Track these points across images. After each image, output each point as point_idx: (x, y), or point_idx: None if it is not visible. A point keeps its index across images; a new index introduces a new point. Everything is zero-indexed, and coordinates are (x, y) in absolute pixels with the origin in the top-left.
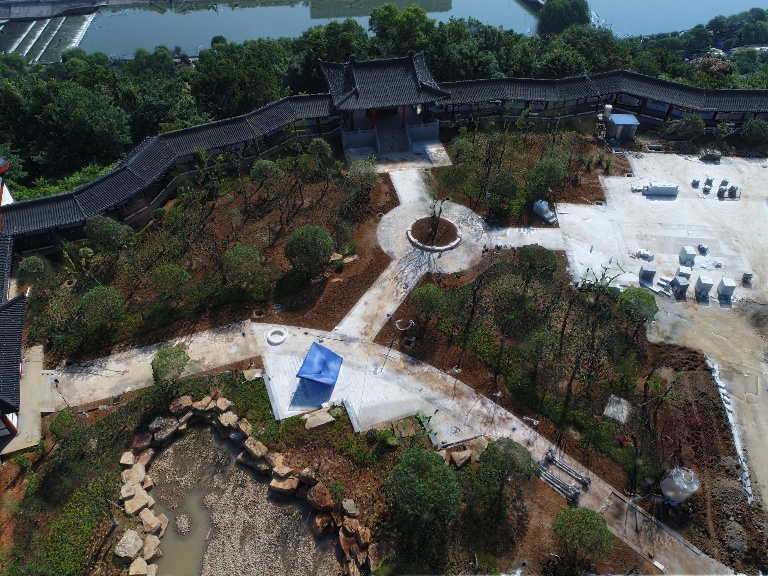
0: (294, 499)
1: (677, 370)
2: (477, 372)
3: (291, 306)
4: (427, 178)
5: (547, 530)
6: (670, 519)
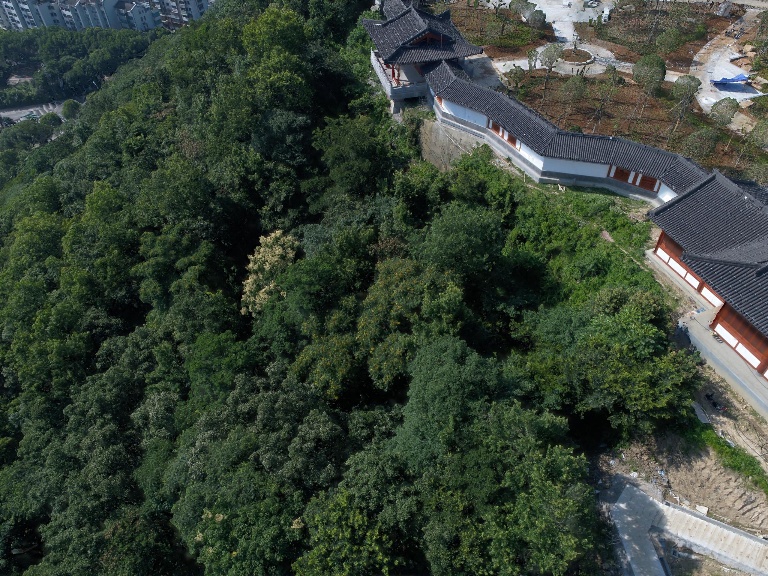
0: None
1: None
2: (690, 47)
3: None
4: (505, 60)
5: None
6: None
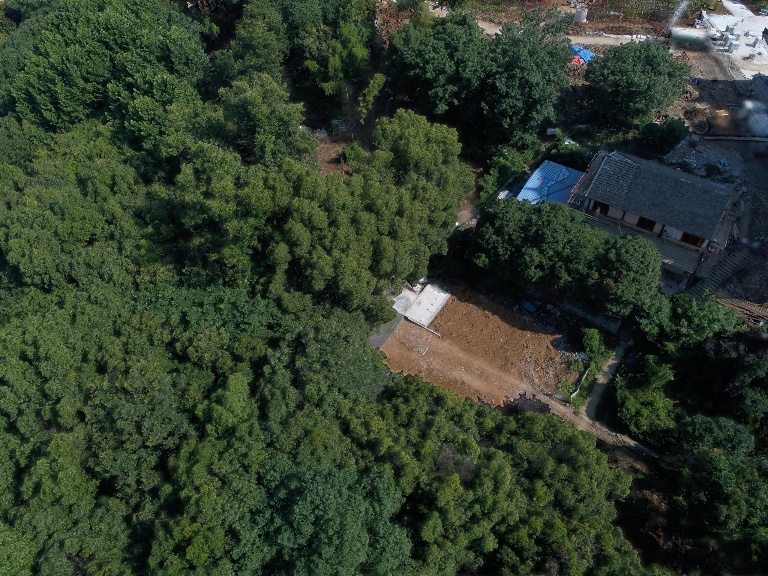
0: None
1: None
2: None
3: None
4: None
5: None
6: None
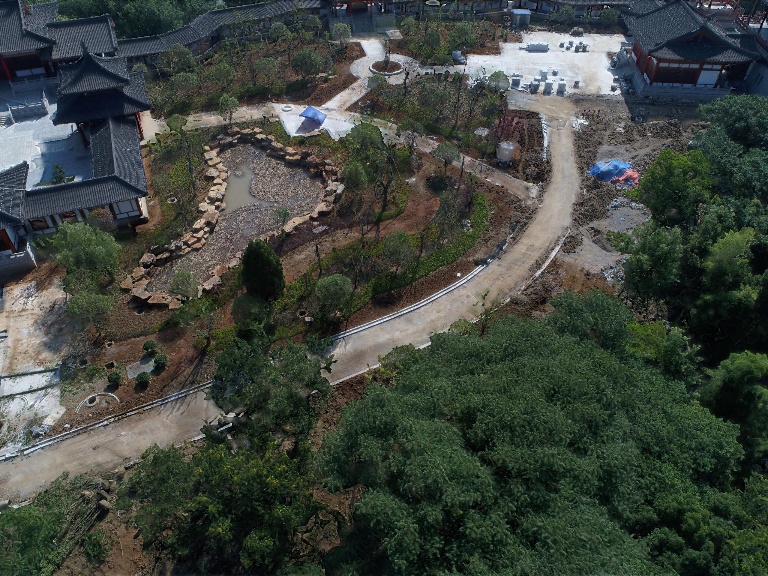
0: (298, 166)
1: (521, 118)
2: None
3: (296, 96)
4: None
5: (432, 169)
6: (499, 167)
